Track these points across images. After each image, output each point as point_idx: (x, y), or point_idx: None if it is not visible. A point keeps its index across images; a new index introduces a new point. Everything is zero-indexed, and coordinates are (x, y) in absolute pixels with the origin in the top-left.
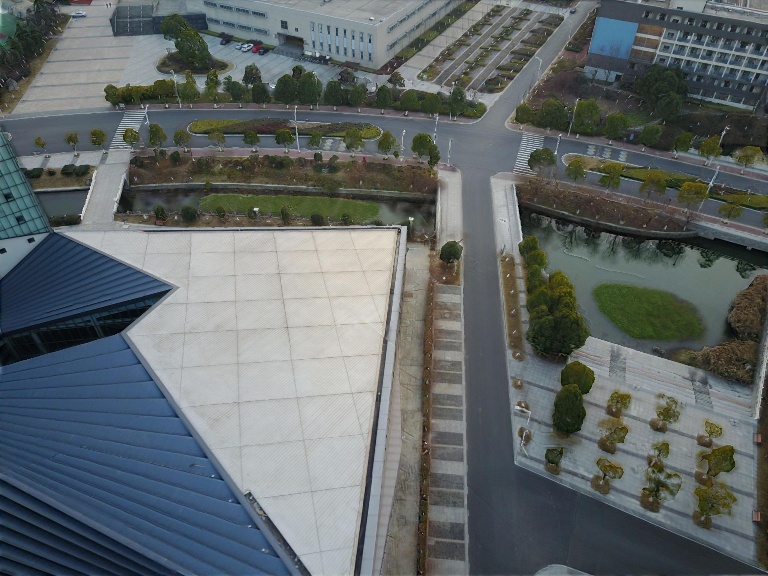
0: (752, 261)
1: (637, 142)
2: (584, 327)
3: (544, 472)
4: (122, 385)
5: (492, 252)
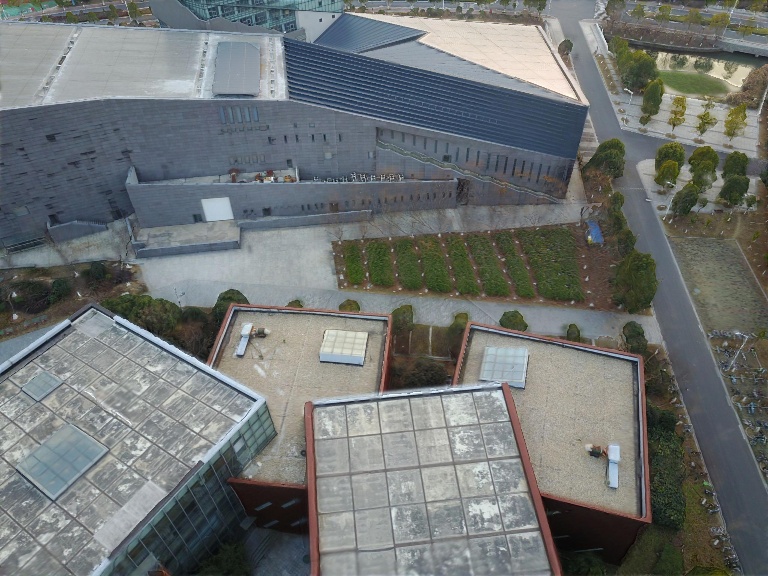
0: (759, 66)
1: (678, 4)
2: (657, 69)
3: (638, 132)
4: (430, 54)
5: (589, 53)
